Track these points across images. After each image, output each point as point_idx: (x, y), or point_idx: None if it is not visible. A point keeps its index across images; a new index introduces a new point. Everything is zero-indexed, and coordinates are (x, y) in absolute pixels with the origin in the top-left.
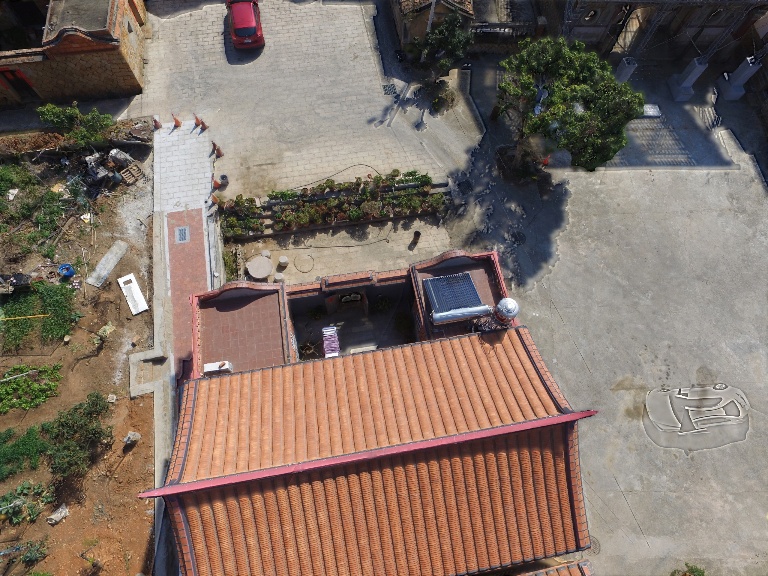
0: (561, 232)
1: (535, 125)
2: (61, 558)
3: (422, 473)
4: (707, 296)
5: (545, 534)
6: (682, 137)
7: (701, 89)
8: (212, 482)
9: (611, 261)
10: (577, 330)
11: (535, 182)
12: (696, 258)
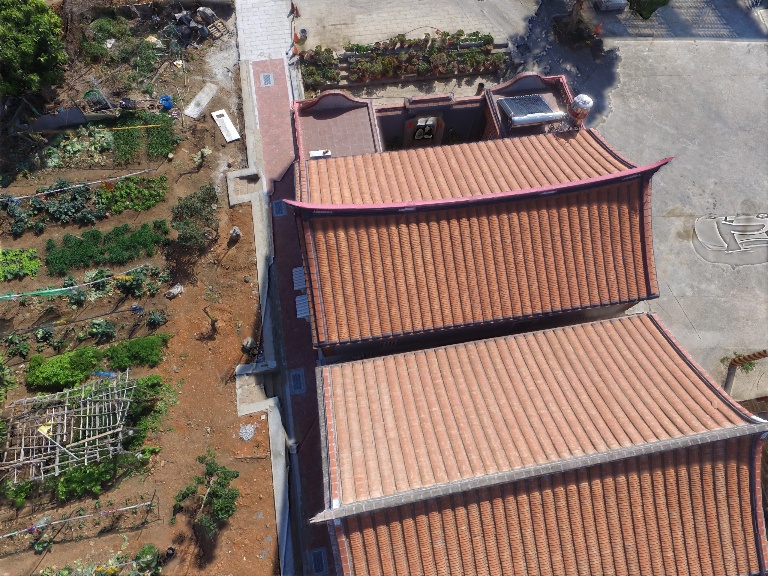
0: (613, 89)
1: None
2: (180, 323)
3: (514, 222)
4: (750, 143)
5: (620, 281)
6: (724, 14)
7: None
8: (339, 206)
9: (660, 114)
10: None
11: (588, 47)
12: (739, 113)
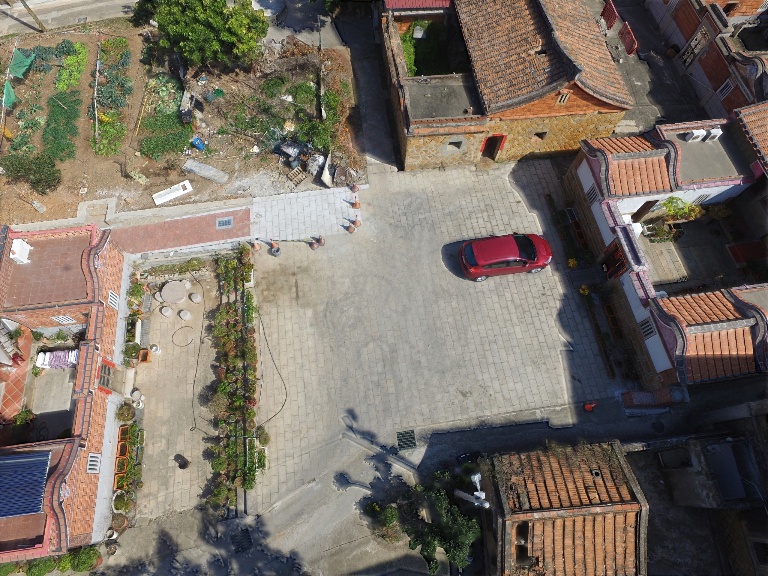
0: None
1: None
2: None
3: None
4: None
5: None
6: None
7: None
8: None
9: None
10: None
11: None
12: None
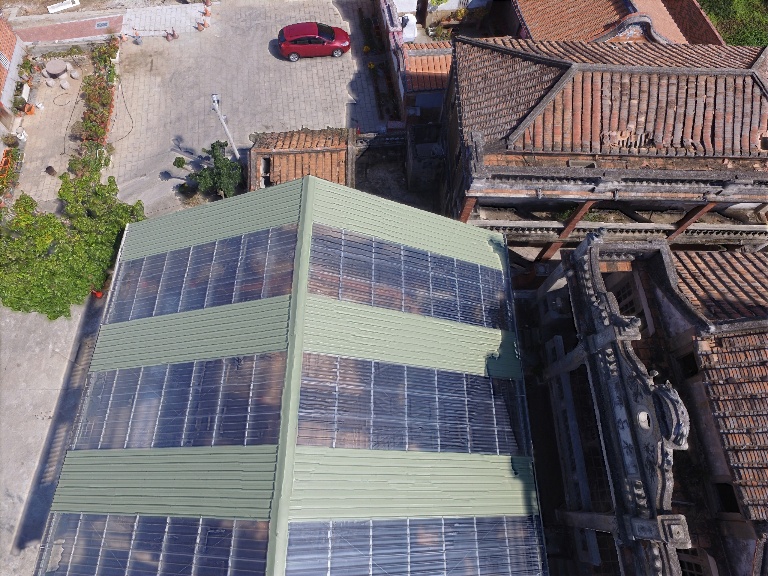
0: None
1: None
2: None
3: None
4: None
5: None
6: None
7: None
8: None
9: None
10: None
11: None
12: None
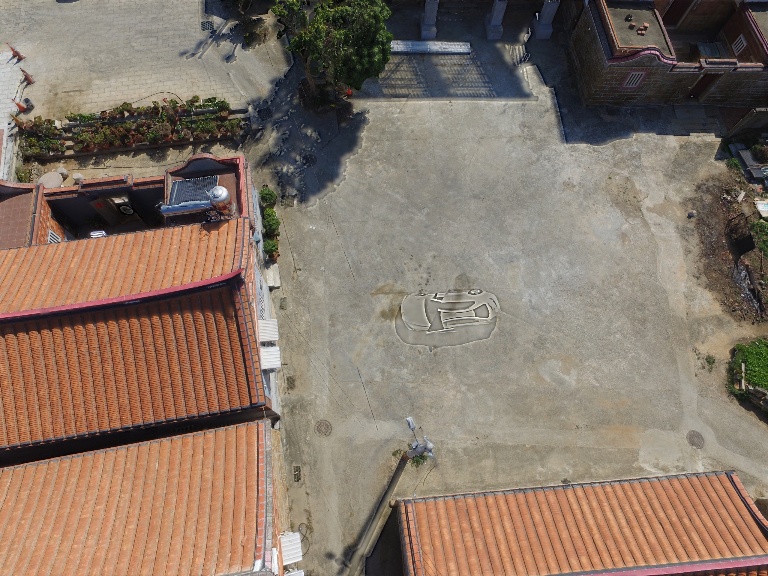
0: (352, 155)
1: (295, 42)
2: None
3: (101, 332)
4: (480, 212)
5: (219, 391)
6: (488, 72)
7: (516, 29)
8: None
9: (395, 181)
10: (349, 241)
11: (334, 110)
12: (477, 179)
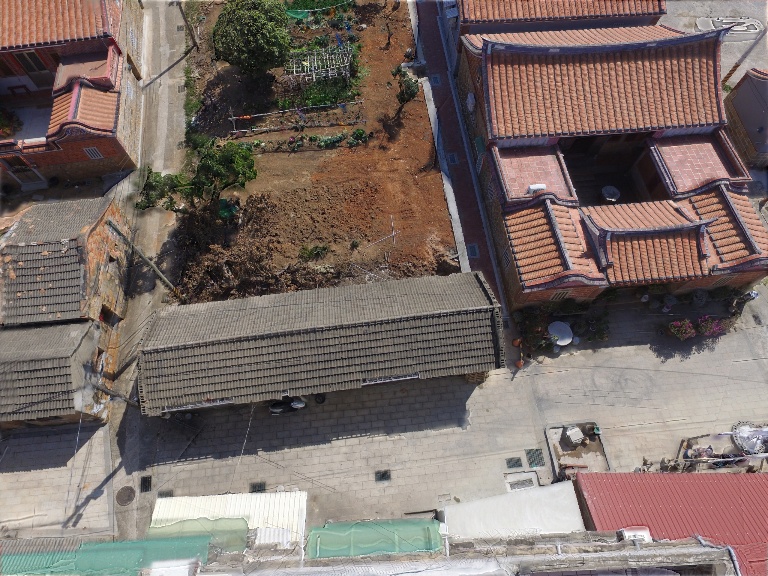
0: None
1: None
2: (367, 41)
3: None
4: None
5: (642, 2)
6: None
7: None
8: None
9: None
10: None
11: None
12: None
